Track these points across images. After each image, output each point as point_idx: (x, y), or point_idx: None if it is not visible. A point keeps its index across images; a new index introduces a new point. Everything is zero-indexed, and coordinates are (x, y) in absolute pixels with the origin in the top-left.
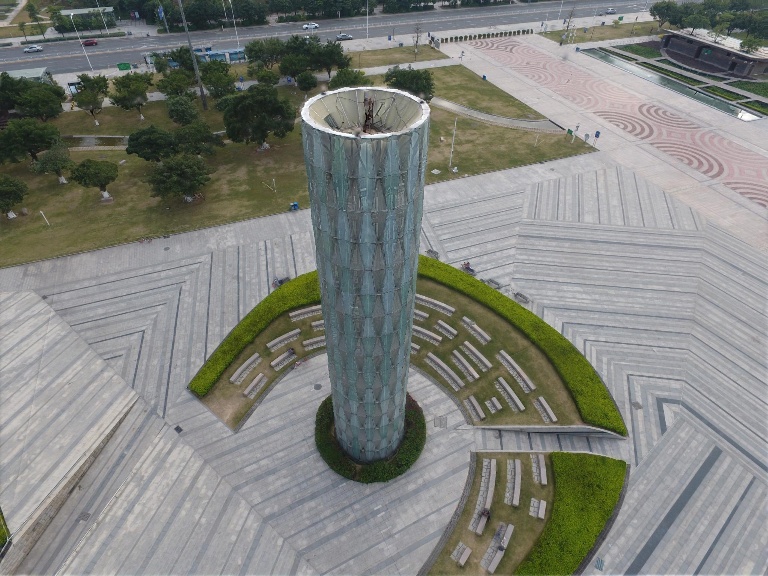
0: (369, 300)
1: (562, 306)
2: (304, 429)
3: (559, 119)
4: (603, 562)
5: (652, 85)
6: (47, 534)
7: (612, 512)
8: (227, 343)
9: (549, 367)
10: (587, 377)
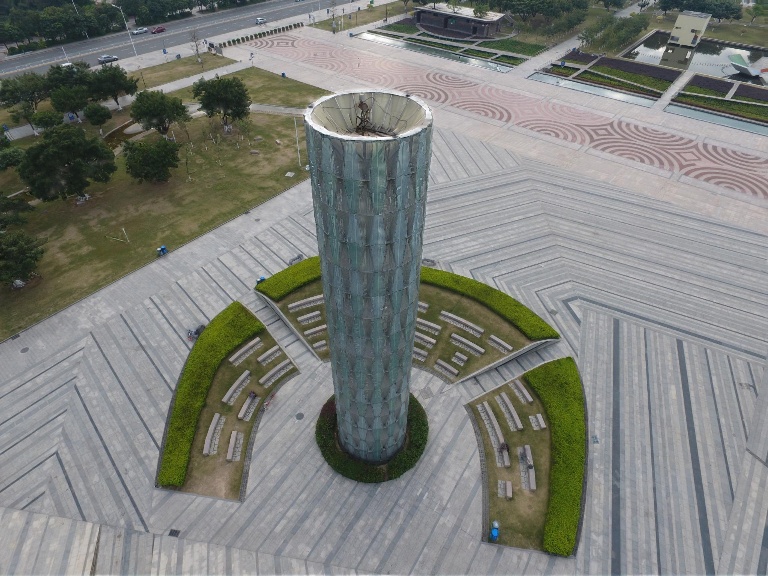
0: (397, 296)
1: (462, 257)
2: (311, 461)
3: None
4: (596, 437)
5: (426, 56)
6: None
7: (583, 397)
8: (176, 419)
9: (484, 309)
10: (513, 305)
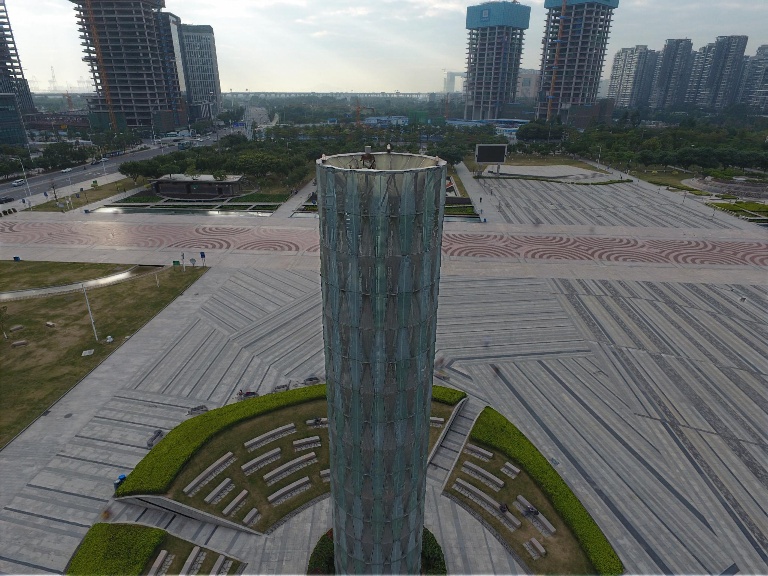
0: None
1: None
2: None
3: (148, 261)
4: (553, 459)
5: (184, 216)
6: None
7: (521, 433)
8: None
9: None
10: None
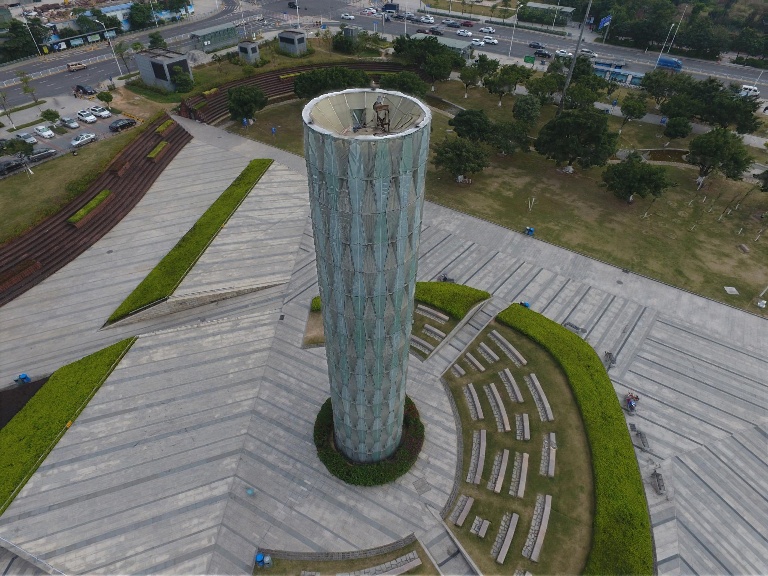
0: None
1: (705, 541)
2: None
3: None
4: None
5: None
6: (185, 312)
7: None
8: None
9: (579, 563)
10: None
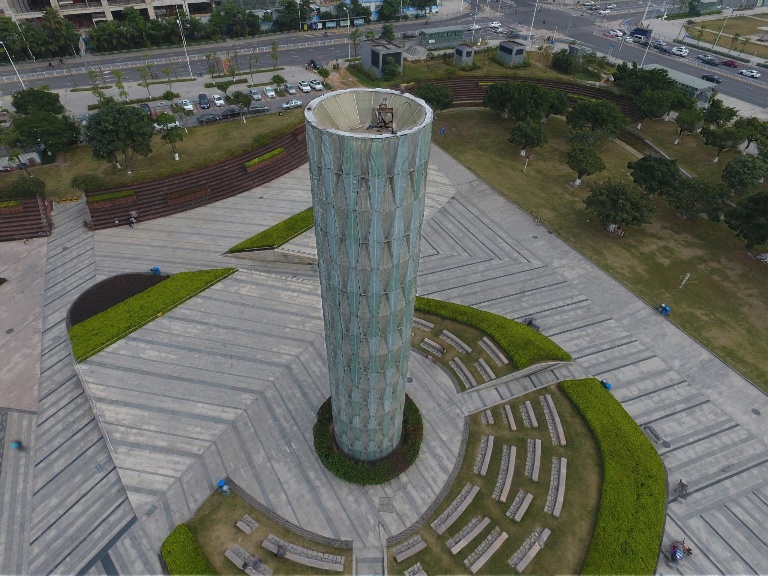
0: None
1: None
2: None
3: None
4: None
5: None
6: (285, 264)
7: None
8: (438, 302)
9: None
10: None
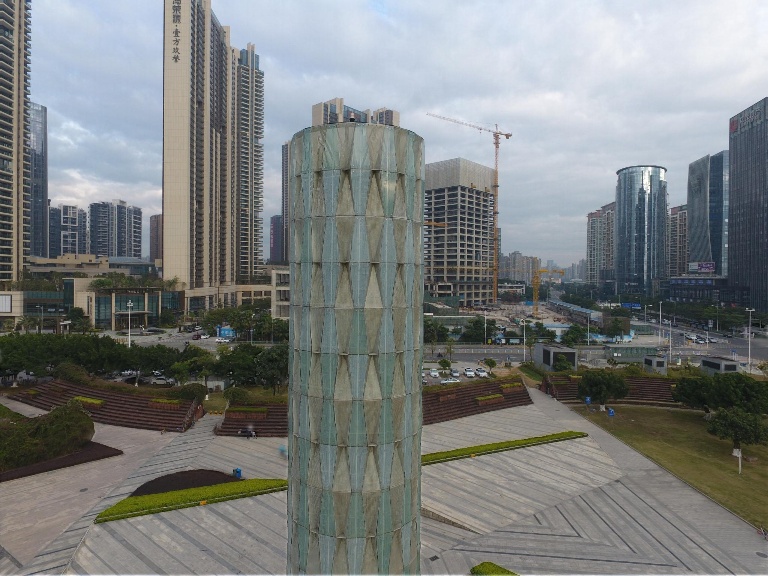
0: None
1: None
2: None
3: None
4: None
5: None
6: None
7: None
8: None
9: None
10: None
